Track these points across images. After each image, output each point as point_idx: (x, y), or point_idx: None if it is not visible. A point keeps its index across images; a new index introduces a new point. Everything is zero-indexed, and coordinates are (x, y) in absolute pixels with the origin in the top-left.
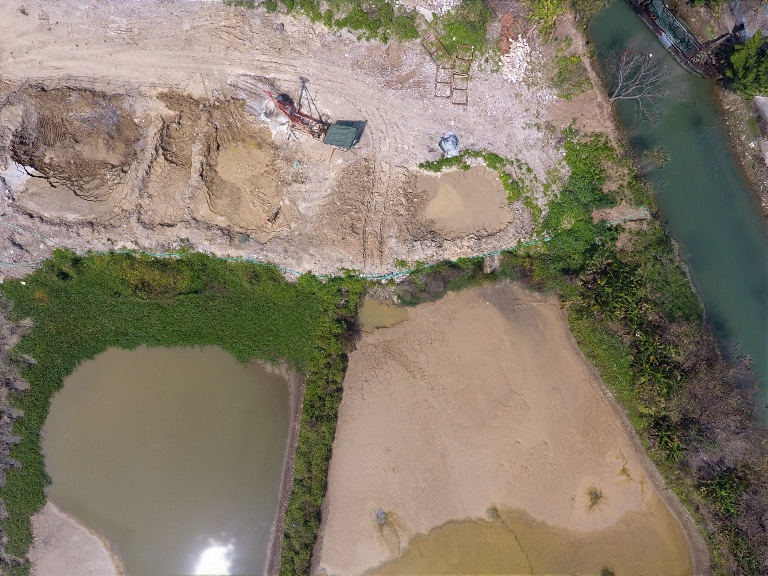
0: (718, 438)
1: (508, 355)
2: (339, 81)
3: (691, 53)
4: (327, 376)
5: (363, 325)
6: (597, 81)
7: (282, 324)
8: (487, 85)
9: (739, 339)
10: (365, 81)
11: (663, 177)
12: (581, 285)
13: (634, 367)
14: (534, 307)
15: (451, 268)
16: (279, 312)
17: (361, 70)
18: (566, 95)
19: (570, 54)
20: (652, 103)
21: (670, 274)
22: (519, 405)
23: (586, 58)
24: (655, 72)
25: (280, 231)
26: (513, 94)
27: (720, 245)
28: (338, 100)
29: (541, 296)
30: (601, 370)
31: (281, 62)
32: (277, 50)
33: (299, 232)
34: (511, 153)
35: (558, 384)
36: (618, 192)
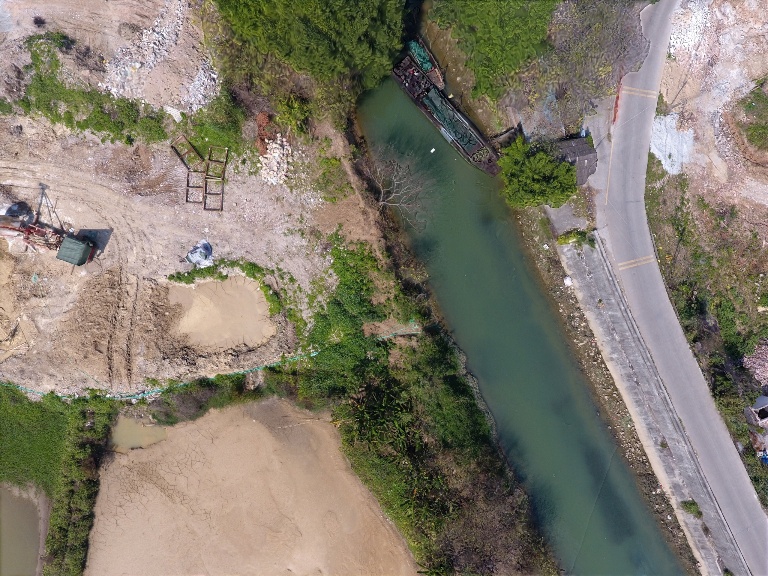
0: (501, 572)
1: (277, 476)
2: (82, 187)
3: (474, 149)
4: (68, 505)
5: (117, 445)
6: (360, 185)
7: (28, 445)
8: (245, 188)
9: (534, 458)
10: (110, 186)
11: (448, 282)
12: (351, 403)
13: (407, 494)
14: (306, 424)
15: (203, 388)
16: (24, 433)
17: (106, 174)
18: (331, 198)
19: (331, 155)
20: (411, 213)
21: (441, 395)
22: (290, 530)
23: (347, 160)
24: (405, 183)
25: (18, 349)
26: (274, 197)
27: (517, 353)
28: (81, 207)
29: (313, 413)
30: (375, 495)
31: (19, 167)
32: (13, 155)
33: (38, 351)
34: (272, 262)
35: (333, 507)
36: (385, 305)
